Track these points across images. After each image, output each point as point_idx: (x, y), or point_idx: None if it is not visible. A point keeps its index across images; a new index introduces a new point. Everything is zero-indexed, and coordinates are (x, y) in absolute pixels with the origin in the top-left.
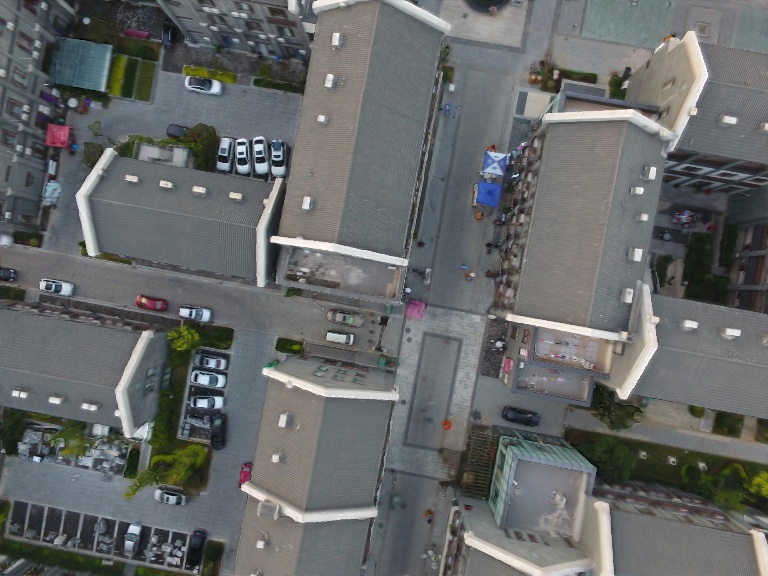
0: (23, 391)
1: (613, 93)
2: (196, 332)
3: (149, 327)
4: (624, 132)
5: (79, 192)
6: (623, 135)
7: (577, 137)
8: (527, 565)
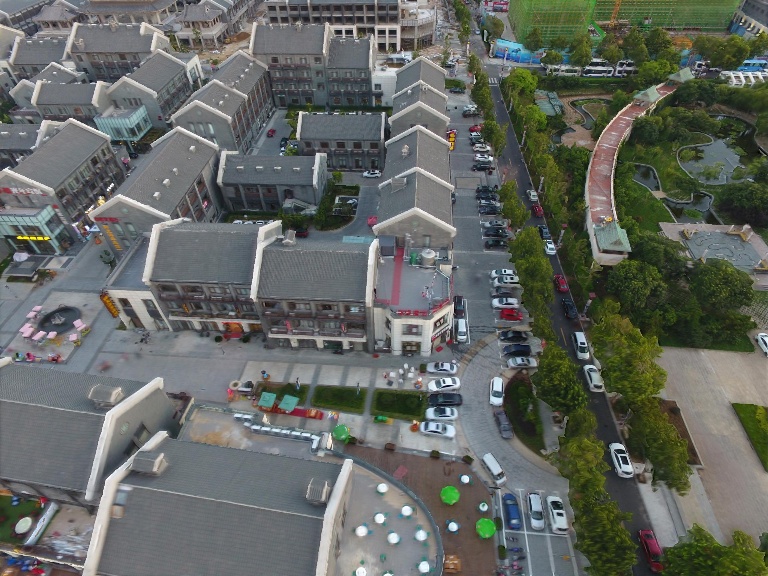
0: (351, 114)
1: (1, 270)
2: (284, 154)
3: (307, 152)
4: (13, 170)
5: (319, 154)
6: (14, 169)
7: (39, 179)
8: (130, 81)
